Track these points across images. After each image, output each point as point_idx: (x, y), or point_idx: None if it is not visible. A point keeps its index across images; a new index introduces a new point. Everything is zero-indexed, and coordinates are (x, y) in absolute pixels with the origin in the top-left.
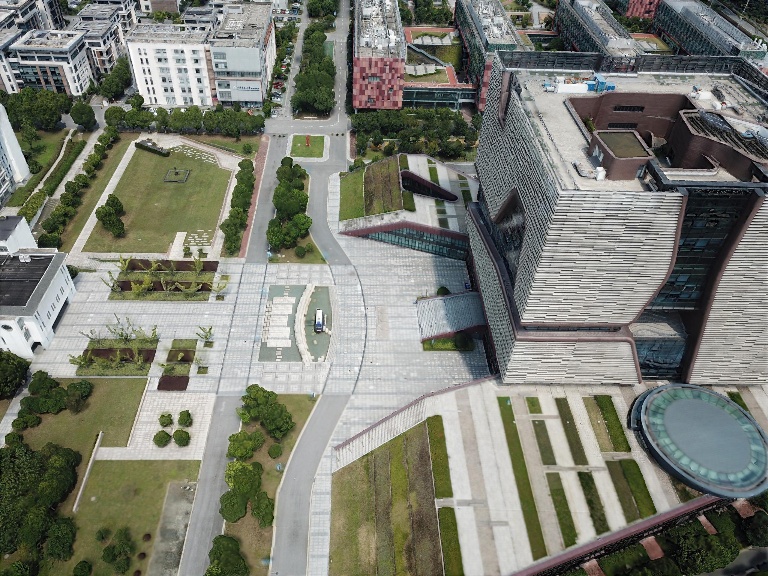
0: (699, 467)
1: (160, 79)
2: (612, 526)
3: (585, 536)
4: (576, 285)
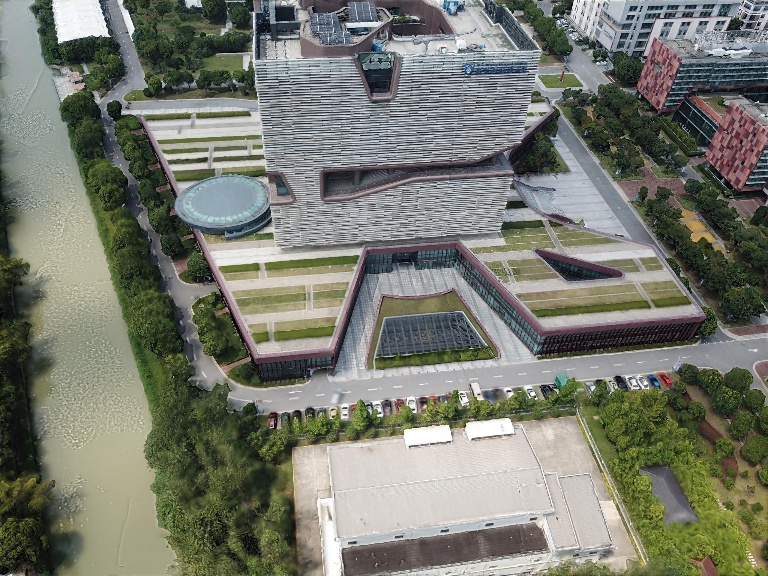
0: None
1: (583, 2)
2: (171, 166)
3: (167, 156)
4: None
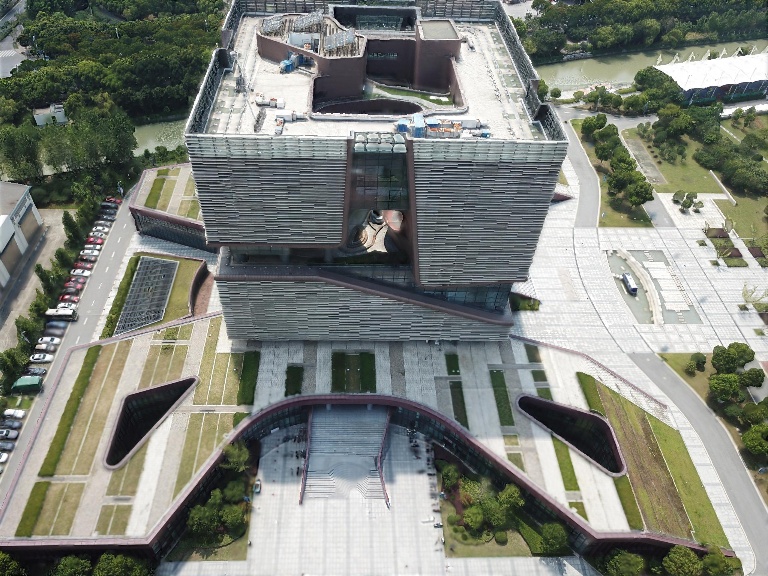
0: None
1: None
2: None
3: None
4: None
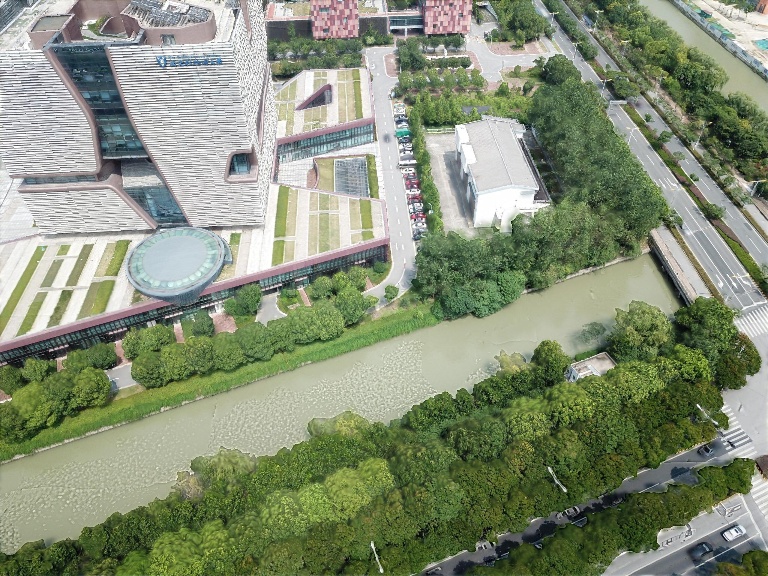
0: (149, 279)
1: None
2: (63, 322)
3: (36, 329)
4: (26, 138)
